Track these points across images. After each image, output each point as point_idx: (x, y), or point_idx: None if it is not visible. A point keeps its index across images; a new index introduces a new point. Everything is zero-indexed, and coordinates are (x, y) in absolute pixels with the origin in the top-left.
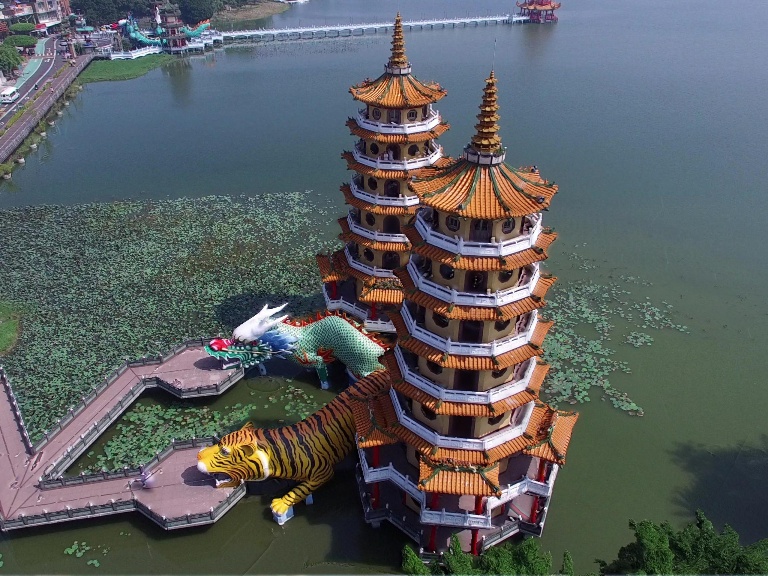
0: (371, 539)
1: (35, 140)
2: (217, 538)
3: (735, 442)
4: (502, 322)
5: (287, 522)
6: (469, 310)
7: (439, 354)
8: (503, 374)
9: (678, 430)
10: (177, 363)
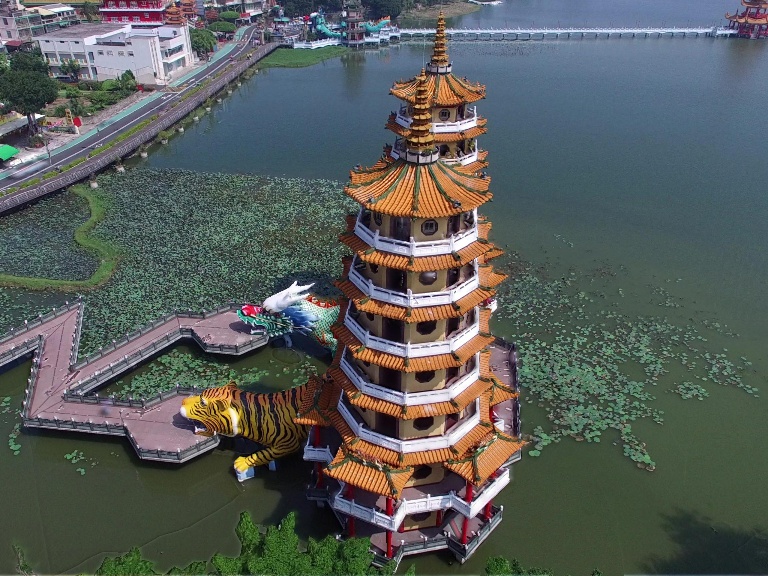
0: (315, 517)
1: (200, 113)
2: (186, 478)
3: (753, 526)
4: (407, 323)
5: (246, 480)
6: (383, 306)
7: (359, 345)
8: (430, 380)
9: (687, 496)
10: (216, 321)
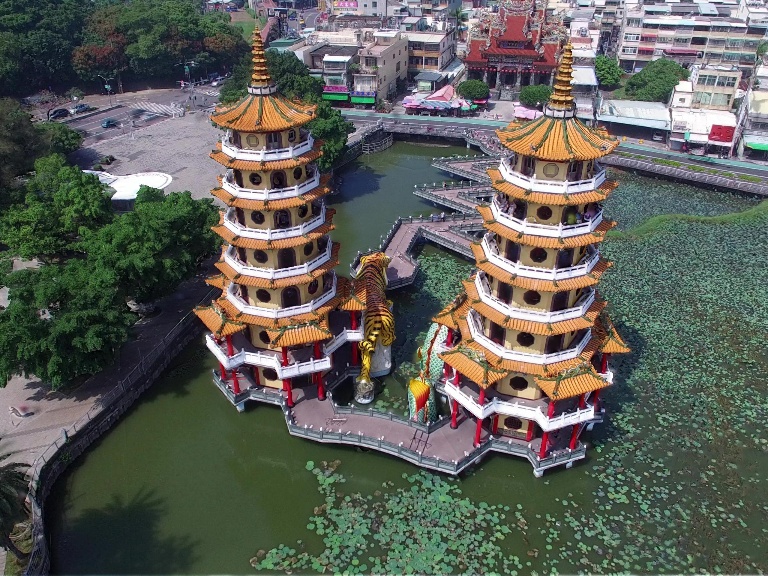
0: None
1: None
2: None
3: None
4: None
5: None
6: None
7: None
8: None
9: None
10: None
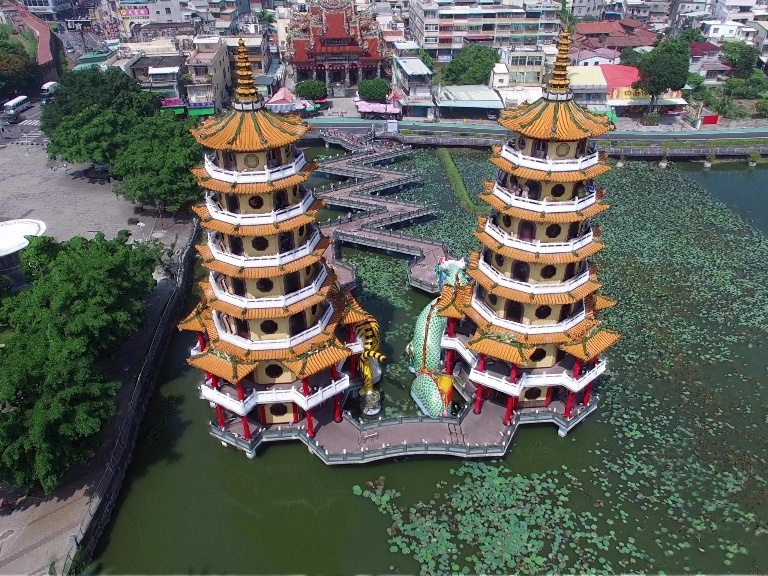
0: None
1: None
2: None
3: None
4: None
5: None
6: None
7: None
8: None
9: None
10: None
